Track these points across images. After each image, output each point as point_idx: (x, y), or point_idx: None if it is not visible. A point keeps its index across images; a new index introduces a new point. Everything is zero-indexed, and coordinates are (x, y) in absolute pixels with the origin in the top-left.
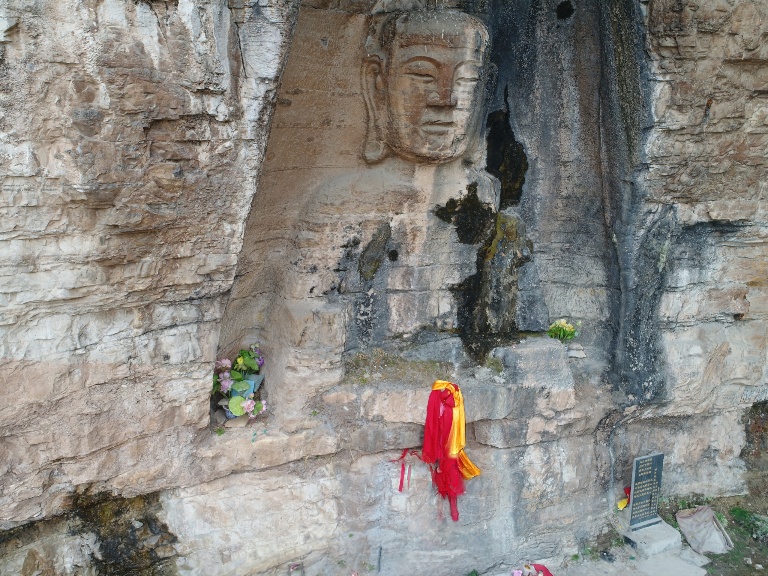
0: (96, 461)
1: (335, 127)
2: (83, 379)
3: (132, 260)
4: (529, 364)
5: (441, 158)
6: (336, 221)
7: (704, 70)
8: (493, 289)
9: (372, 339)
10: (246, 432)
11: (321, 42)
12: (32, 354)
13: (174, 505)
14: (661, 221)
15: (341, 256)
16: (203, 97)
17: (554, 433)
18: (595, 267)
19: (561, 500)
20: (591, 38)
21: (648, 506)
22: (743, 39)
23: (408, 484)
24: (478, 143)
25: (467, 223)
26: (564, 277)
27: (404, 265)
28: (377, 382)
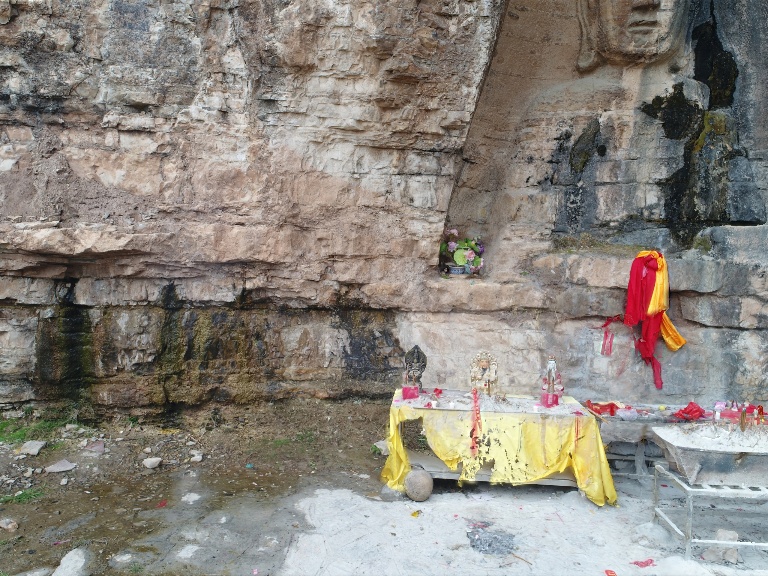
0: (356, 264)
1: (553, 44)
2: (355, 198)
3: (398, 105)
4: (740, 241)
5: (646, 54)
6: (551, 117)
7: None
8: (701, 180)
9: (580, 226)
10: (466, 280)
11: None
12: (328, 169)
13: (405, 327)
14: None
15: (554, 148)
16: None
17: None
18: None
19: None
20: None
21: None
22: None
23: (610, 348)
24: (684, 48)
25: (673, 119)
26: None
27: (612, 160)
28: (583, 252)
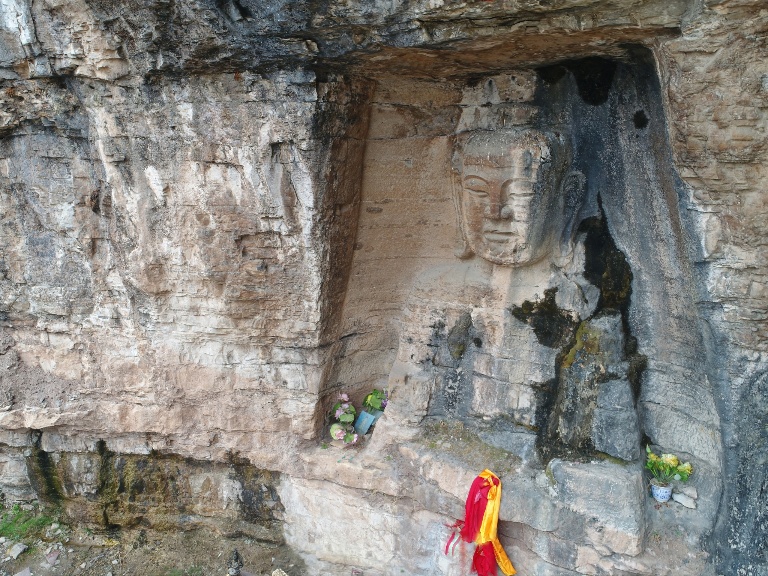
0: (236, 437)
1: (433, 226)
2: (231, 383)
3: (247, 317)
4: (581, 488)
5: None
6: (425, 305)
7: (753, 204)
8: (569, 398)
9: (457, 412)
10: (340, 453)
11: (405, 162)
12: (203, 362)
13: (287, 486)
14: None
15: (431, 334)
16: (269, 221)
17: (610, 574)
18: (714, 406)
19: None
20: None
21: None
22: None
23: (453, 552)
24: (560, 249)
25: (545, 326)
26: (686, 407)
27: (488, 353)
28: (441, 451)
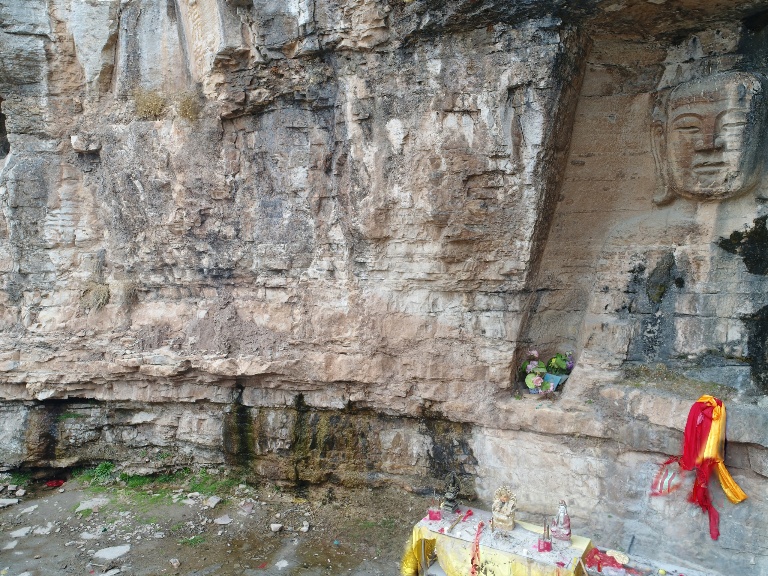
0: (434, 386)
1: (629, 179)
2: (433, 332)
3: (460, 260)
4: None
5: (714, 194)
6: (624, 251)
7: None
8: None
9: (658, 355)
10: (536, 403)
11: (609, 118)
12: (409, 310)
13: (480, 439)
14: None
15: (629, 280)
16: (497, 160)
17: None
18: None
19: None
20: None
21: None
22: None
23: (668, 488)
24: (767, 180)
25: (756, 254)
26: None
27: (691, 292)
28: (648, 387)
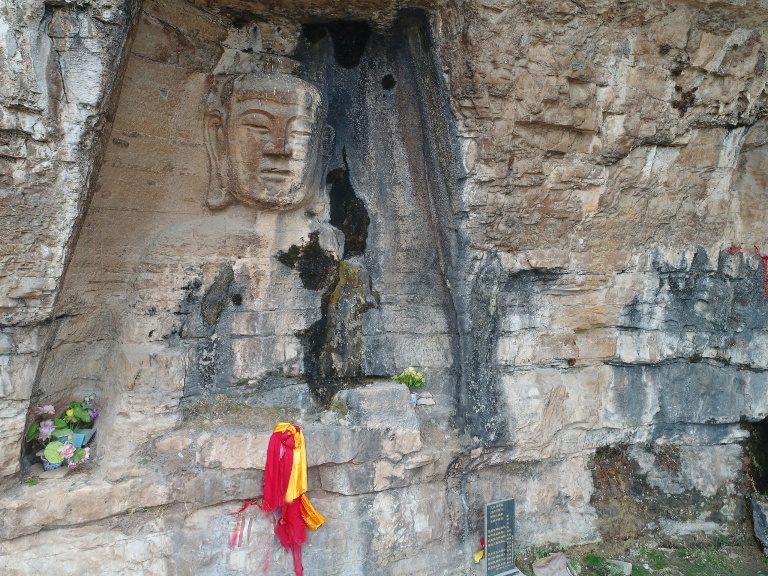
0: None
1: (178, 174)
2: None
3: None
4: (373, 405)
5: (280, 204)
6: (176, 262)
7: (501, 129)
8: (338, 334)
9: (215, 386)
10: (63, 482)
11: (160, 92)
12: None
13: None
14: (487, 267)
15: (182, 298)
16: (18, 114)
17: (402, 478)
18: (437, 315)
19: (414, 552)
20: (412, 106)
21: (504, 556)
22: (528, 104)
23: (248, 538)
24: (318, 195)
25: (310, 269)
26: (411, 327)
27: (249, 310)
28: (216, 427)
